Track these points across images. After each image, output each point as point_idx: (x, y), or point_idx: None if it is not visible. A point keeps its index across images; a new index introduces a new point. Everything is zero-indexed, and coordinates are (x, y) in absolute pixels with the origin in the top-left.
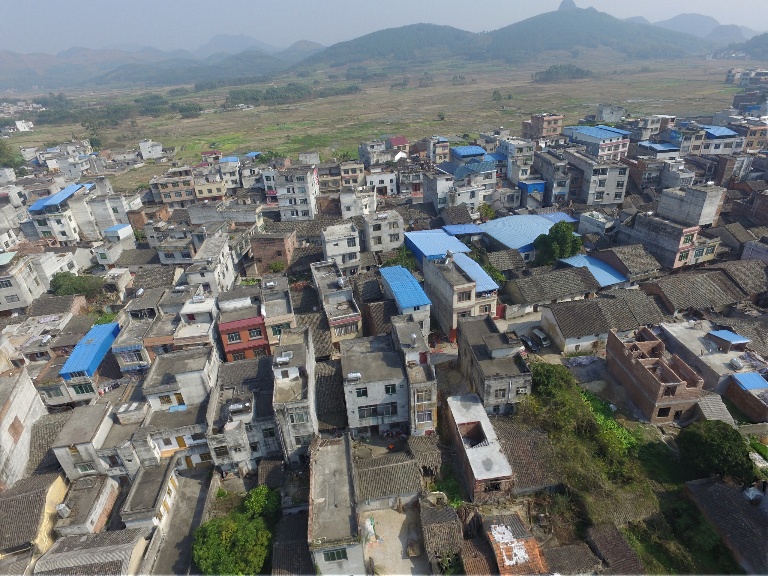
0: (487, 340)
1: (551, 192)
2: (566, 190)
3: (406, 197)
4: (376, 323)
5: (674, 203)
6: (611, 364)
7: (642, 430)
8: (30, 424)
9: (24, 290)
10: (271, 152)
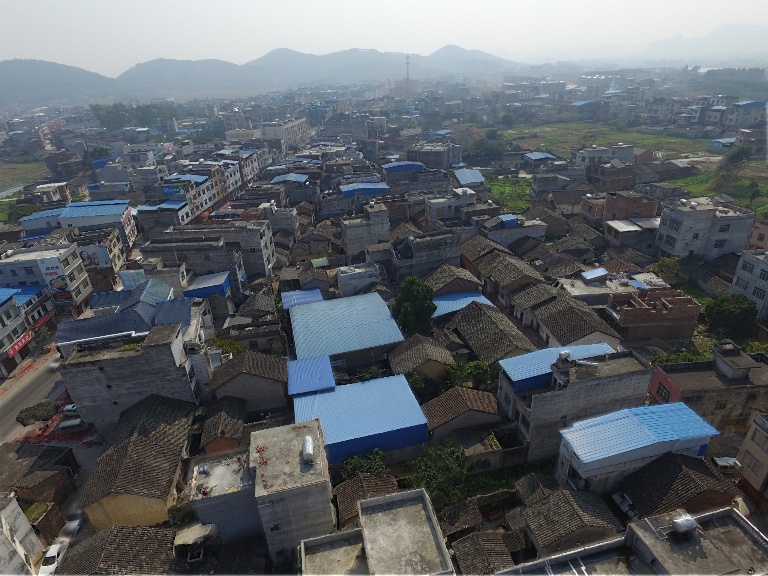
0: (744, 365)
1: (236, 281)
2: (243, 271)
3: None
4: (731, 490)
5: (362, 231)
6: (634, 333)
7: (703, 344)
8: None
9: None
10: None
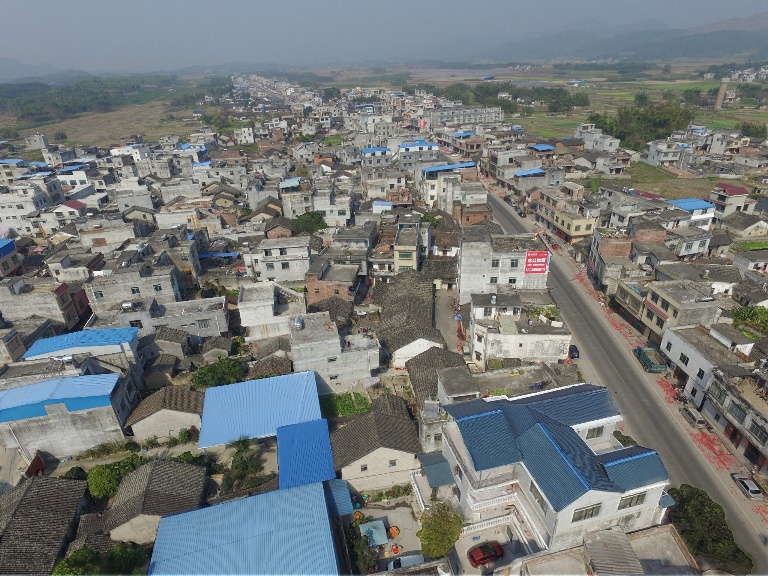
0: None
1: None
2: None
3: None
4: None
5: None
6: None
7: None
8: (115, 247)
9: (287, 209)
10: None
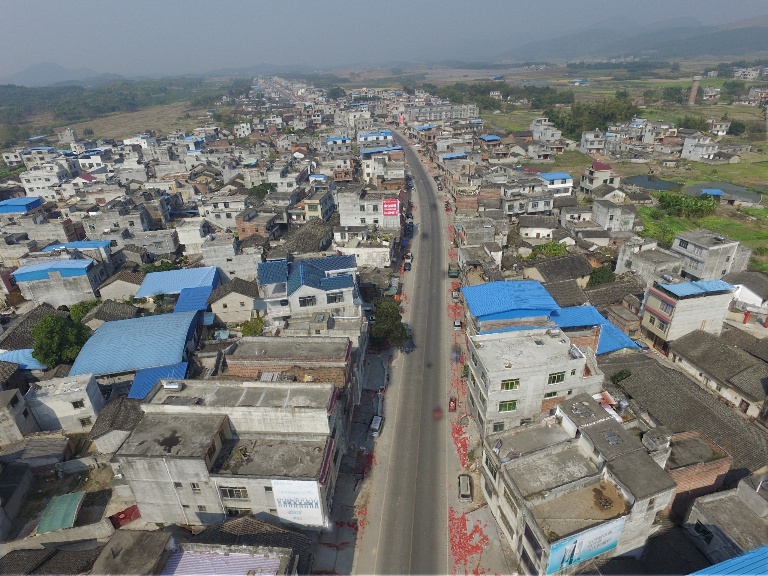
0: None
1: None
2: None
3: (386, 283)
4: None
5: None
6: None
7: None
8: None
9: (247, 181)
10: (706, 197)
